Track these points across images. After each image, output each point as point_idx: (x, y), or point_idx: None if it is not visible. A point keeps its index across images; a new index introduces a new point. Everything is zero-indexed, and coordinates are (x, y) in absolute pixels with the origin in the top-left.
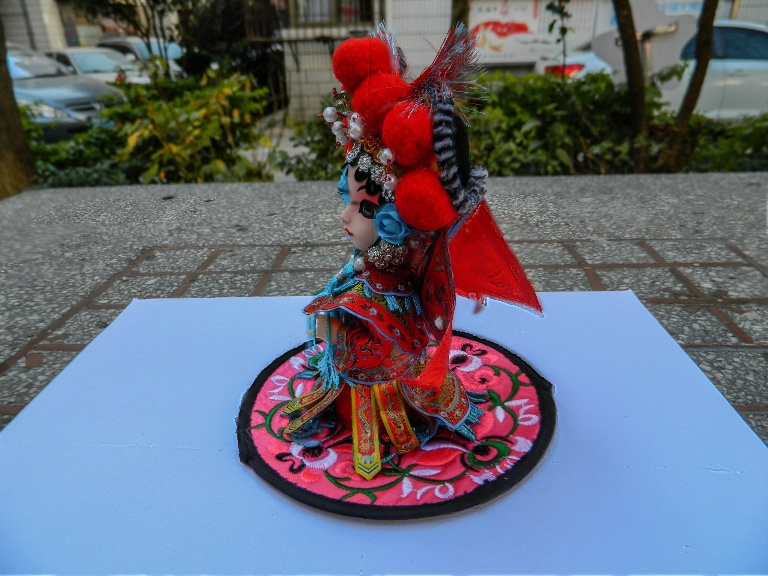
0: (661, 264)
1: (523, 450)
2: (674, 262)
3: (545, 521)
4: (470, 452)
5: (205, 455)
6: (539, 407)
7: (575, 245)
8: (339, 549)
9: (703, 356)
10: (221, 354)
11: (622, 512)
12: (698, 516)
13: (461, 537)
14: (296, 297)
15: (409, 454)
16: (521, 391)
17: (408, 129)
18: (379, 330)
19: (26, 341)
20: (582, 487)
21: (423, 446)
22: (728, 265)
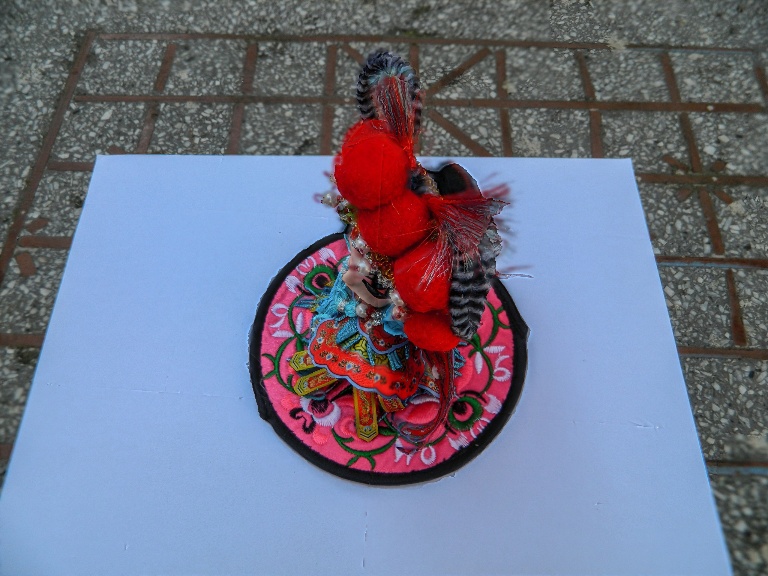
0: (674, 105)
1: (494, 412)
2: (688, 101)
3: (502, 480)
4: (450, 409)
5: (228, 404)
6: (513, 361)
7: (588, 56)
8: (349, 506)
9: (672, 274)
10: (215, 261)
11: (560, 471)
12: (614, 475)
13: (439, 495)
14: (277, 158)
15: (400, 410)
16: (500, 335)
17: (423, 300)
18: (382, 396)
19: (4, 230)
20: (534, 445)
21: (412, 400)
22: (743, 110)
